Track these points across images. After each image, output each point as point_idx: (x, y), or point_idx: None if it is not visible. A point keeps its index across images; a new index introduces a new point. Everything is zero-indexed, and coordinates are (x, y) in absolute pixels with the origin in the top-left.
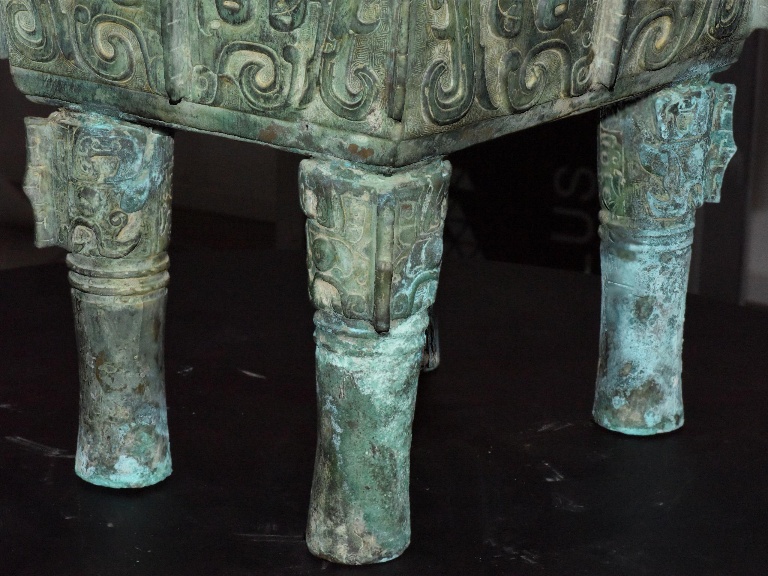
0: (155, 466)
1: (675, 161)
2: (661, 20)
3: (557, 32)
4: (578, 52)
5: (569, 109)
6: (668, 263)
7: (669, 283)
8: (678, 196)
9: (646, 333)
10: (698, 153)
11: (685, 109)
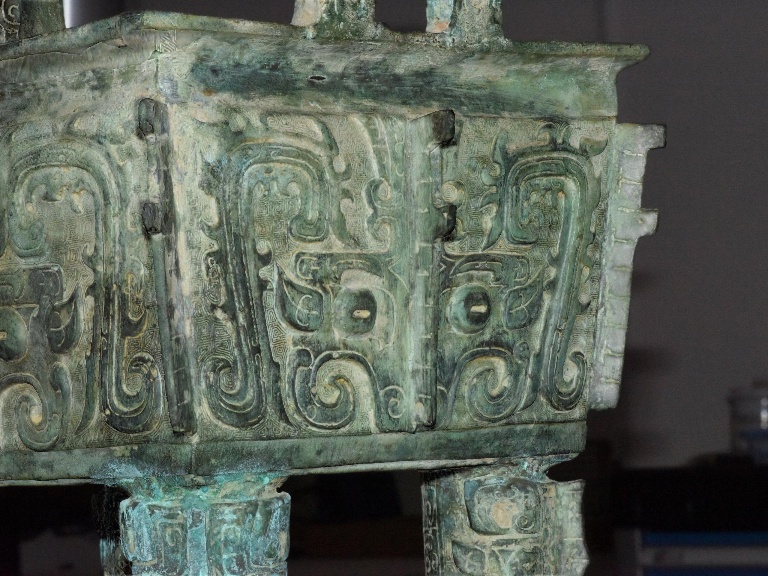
0: None
1: None
2: None
3: None
4: None
5: None
6: None
7: None
8: None
9: None
10: None
11: None
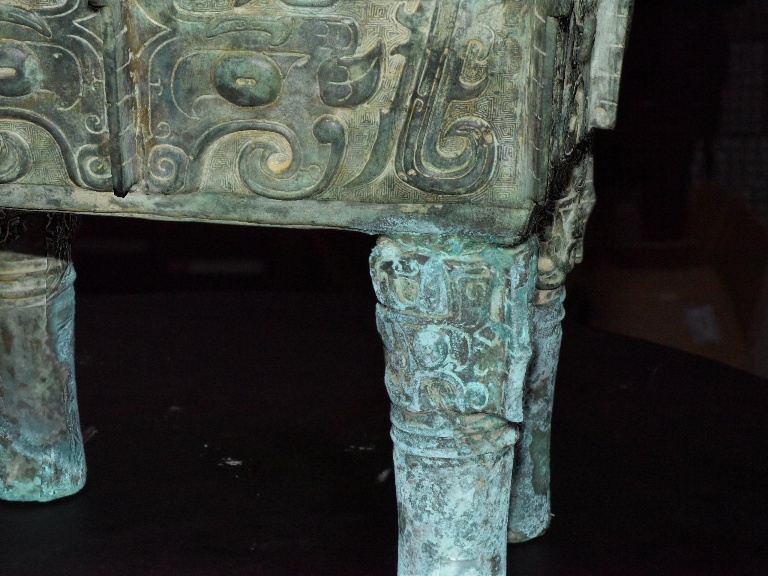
0: (11, 483)
1: (401, 337)
2: (274, 136)
3: (26, 101)
4: (80, 136)
5: (114, 206)
6: (413, 469)
7: (417, 496)
8: (407, 384)
9: (404, 550)
10: (425, 337)
11: (405, 273)
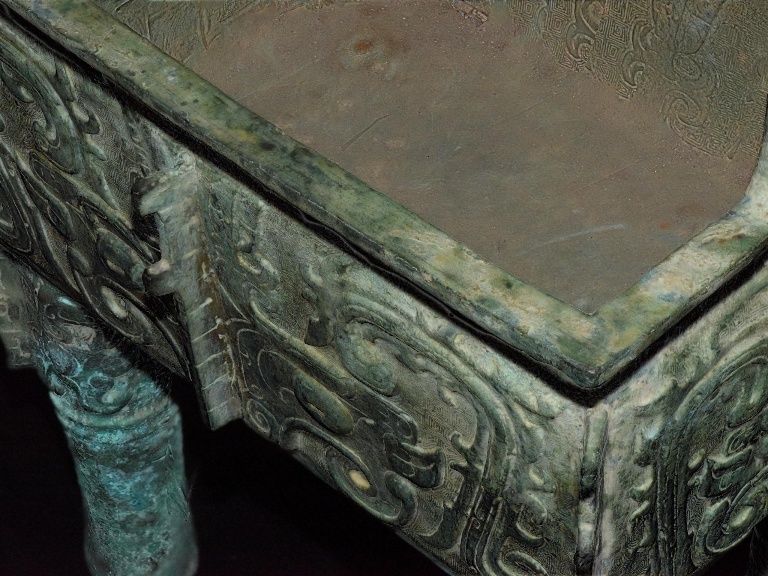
0: None
1: None
2: None
3: None
4: None
5: None
6: None
7: None
8: None
9: None
10: None
11: None
